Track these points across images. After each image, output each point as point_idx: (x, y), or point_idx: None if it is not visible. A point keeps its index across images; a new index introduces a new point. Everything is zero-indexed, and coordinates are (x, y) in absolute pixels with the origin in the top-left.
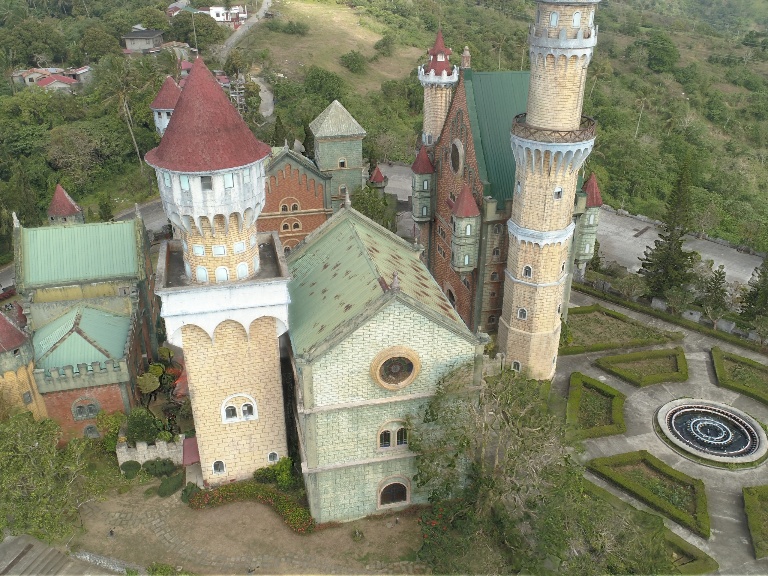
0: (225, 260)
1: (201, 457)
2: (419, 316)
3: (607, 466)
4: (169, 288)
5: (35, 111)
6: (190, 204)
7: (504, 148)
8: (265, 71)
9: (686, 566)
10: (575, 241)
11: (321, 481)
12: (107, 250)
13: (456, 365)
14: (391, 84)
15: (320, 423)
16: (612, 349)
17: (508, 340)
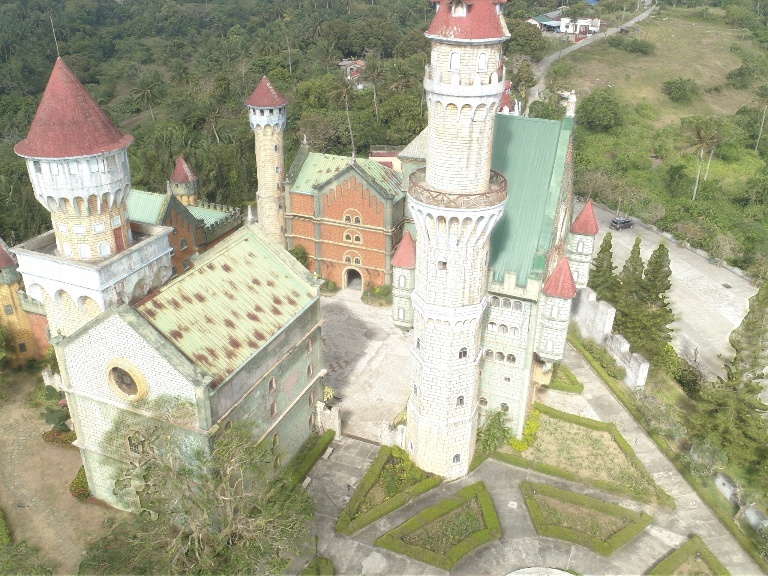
0: (69, 238)
1: (68, 402)
2: (138, 336)
3: None
4: (21, 248)
5: (320, 96)
6: (33, 182)
7: None
8: (550, 87)
9: None
10: (531, 331)
11: (90, 459)
12: (139, 215)
13: (180, 399)
14: (687, 119)
15: (79, 404)
16: (567, 479)
17: (407, 414)
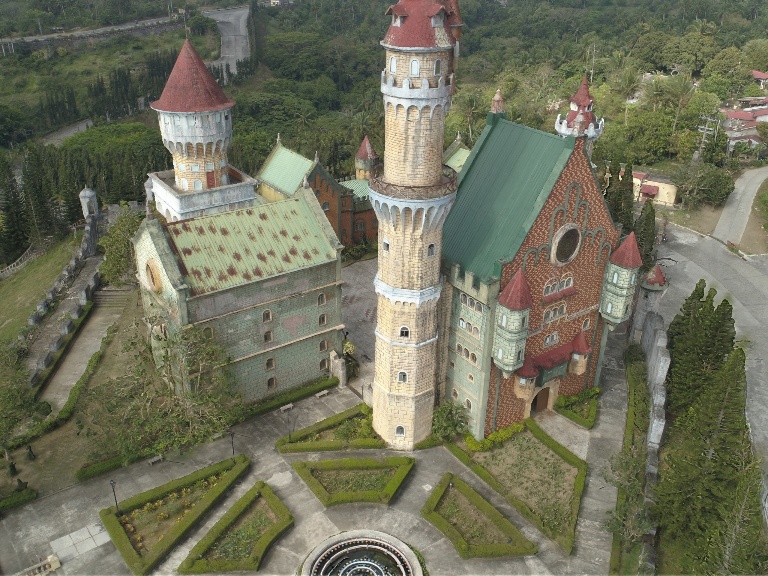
0: None
1: None
2: None
3: (257, 492)
4: None
5: None
6: None
7: (474, 203)
8: None
9: (131, 549)
10: (486, 335)
11: None
12: None
13: None
14: None
15: None
16: None
17: None
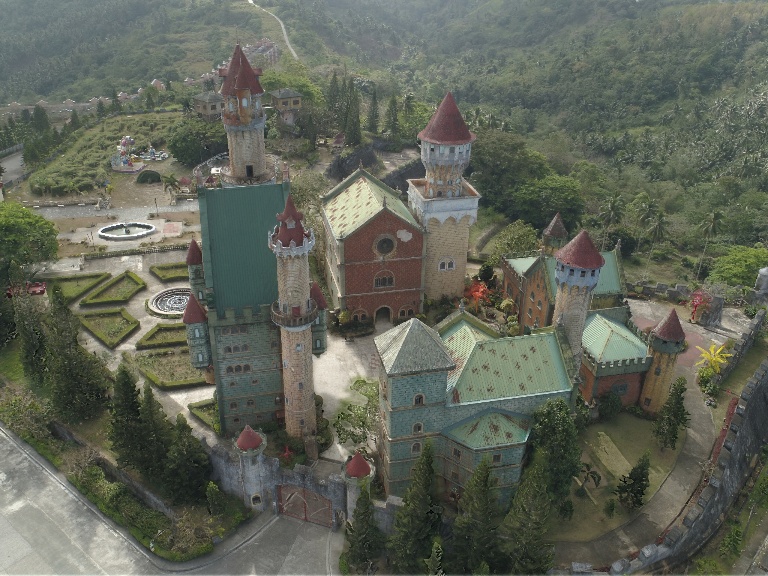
0: None
1: None
2: None
3: None
4: None
5: None
6: None
7: None
8: None
9: None
10: None
11: None
12: None
13: None
14: None
15: None
16: None
17: None
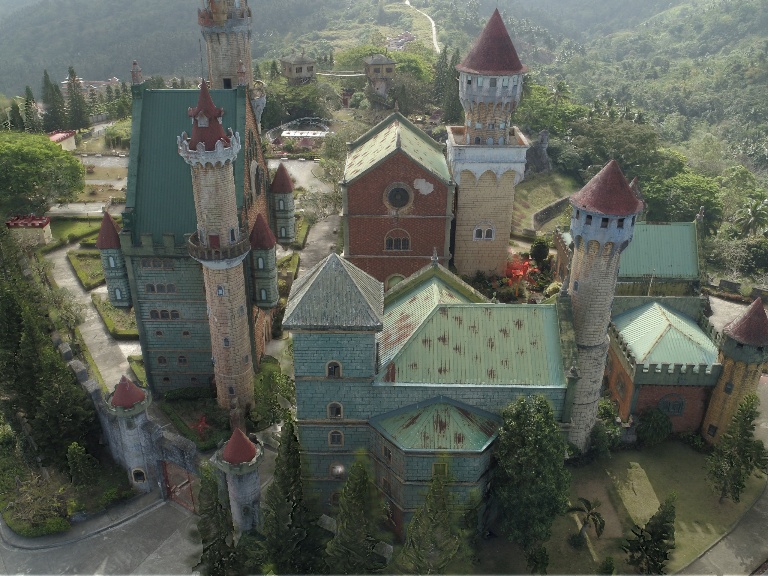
0: None
1: None
2: None
3: None
4: None
5: None
6: None
7: None
8: None
9: None
10: None
11: None
12: None
13: None
14: None
15: None
16: None
17: None
